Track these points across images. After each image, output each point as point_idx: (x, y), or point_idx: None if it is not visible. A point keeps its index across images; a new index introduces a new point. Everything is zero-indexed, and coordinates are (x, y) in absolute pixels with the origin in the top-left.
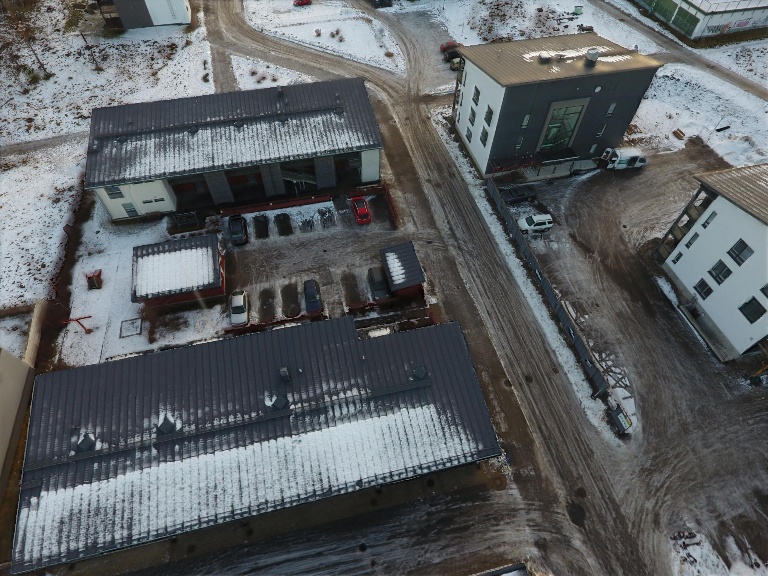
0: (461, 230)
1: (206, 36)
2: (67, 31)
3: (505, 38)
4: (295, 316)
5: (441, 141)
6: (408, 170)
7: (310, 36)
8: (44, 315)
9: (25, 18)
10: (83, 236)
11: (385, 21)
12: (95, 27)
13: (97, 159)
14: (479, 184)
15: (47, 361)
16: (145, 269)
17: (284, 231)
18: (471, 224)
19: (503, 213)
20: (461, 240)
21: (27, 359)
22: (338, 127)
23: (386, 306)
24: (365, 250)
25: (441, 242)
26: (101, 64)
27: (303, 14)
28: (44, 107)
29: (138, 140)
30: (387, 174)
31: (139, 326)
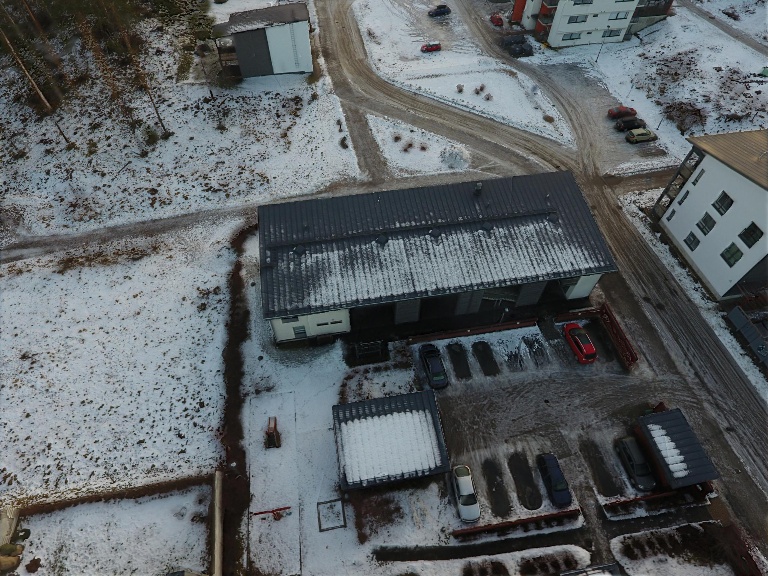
0: (711, 378)
1: (333, 88)
2: (180, 79)
3: (685, 104)
4: (537, 507)
5: (645, 241)
6: (617, 283)
7: (451, 92)
8: (227, 497)
9: (133, 62)
10: (244, 363)
11: (532, 75)
12: (208, 73)
13: (273, 277)
14: (713, 308)
15: (234, 564)
16: (352, 441)
17: (488, 368)
18: (721, 369)
19: (765, 358)
20: (716, 393)
21: (217, 571)
22: (556, 240)
23: (656, 501)
24: (598, 404)
25: (692, 396)
26: (223, 121)
27: (435, 63)
28: (166, 174)
29: (318, 252)
30: (594, 288)
31: (341, 513)
